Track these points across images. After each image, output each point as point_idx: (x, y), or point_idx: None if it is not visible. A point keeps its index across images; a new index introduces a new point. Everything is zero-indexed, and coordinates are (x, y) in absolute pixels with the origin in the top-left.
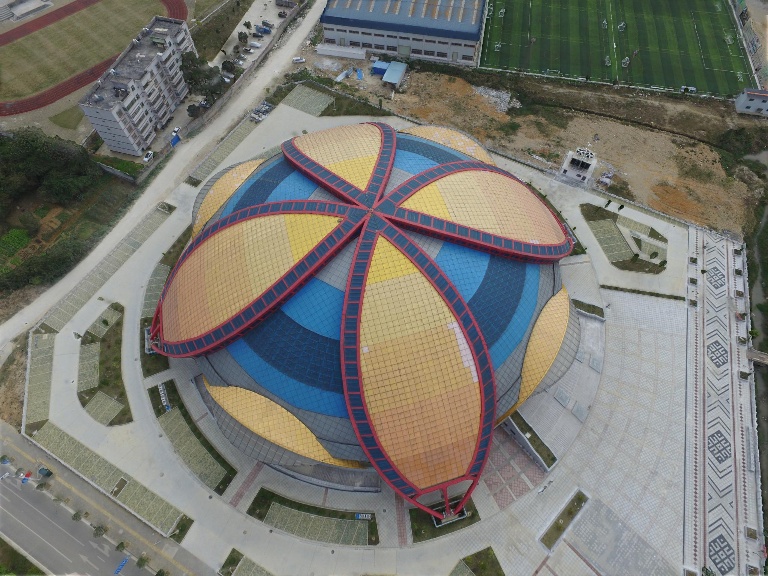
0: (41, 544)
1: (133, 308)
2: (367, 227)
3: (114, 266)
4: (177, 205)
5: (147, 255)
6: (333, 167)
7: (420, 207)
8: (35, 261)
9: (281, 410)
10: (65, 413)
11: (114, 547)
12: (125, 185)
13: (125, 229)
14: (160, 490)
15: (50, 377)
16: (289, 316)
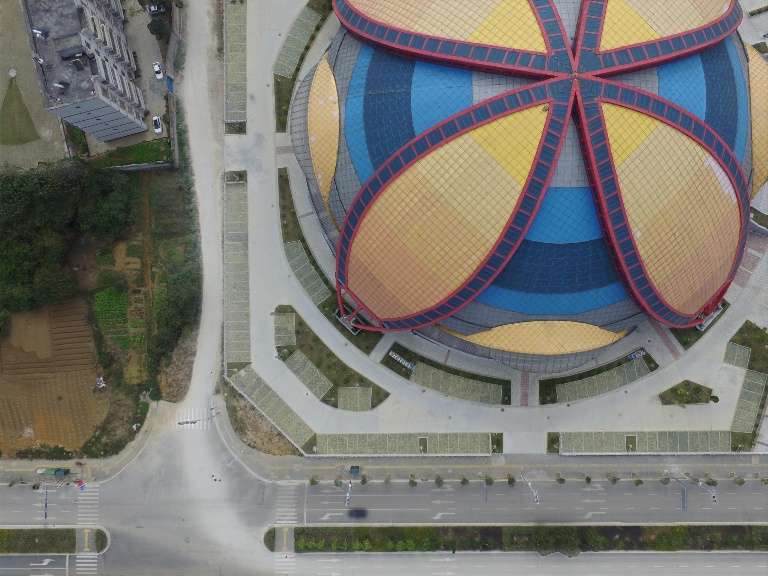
0: (396, 513)
1: (300, 301)
2: (583, 100)
3: (241, 272)
4: (244, 167)
5: (264, 241)
6: (480, 36)
7: (620, 38)
8: (169, 316)
9: (560, 324)
10: (325, 421)
11: (453, 483)
12: (164, 176)
13: (214, 227)
14: (458, 428)
15: (283, 402)
16: (536, 241)
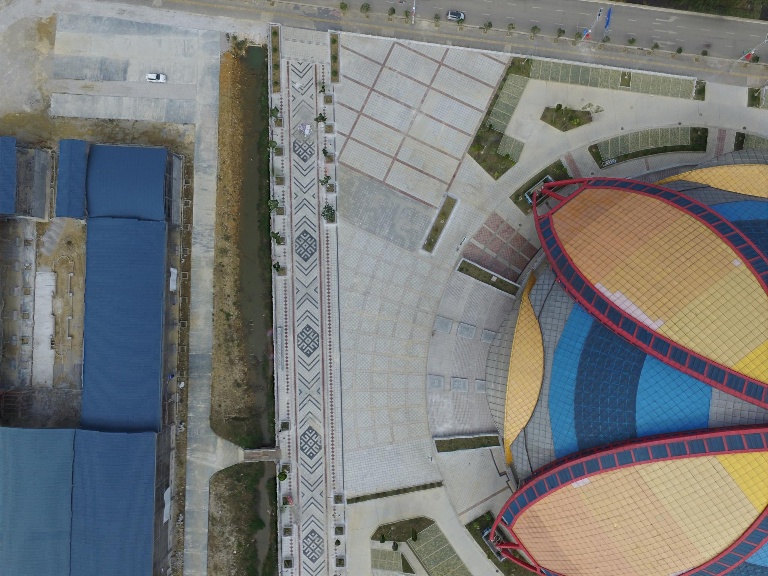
0: None
1: None
2: None
3: None
4: None
5: None
6: None
7: None
8: None
9: (760, 194)
10: None
11: None
12: None
13: None
14: None
15: None
16: None
